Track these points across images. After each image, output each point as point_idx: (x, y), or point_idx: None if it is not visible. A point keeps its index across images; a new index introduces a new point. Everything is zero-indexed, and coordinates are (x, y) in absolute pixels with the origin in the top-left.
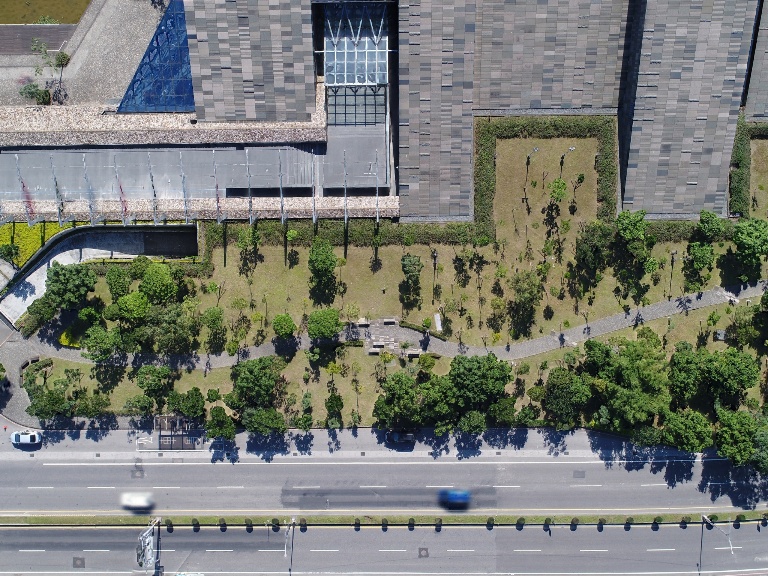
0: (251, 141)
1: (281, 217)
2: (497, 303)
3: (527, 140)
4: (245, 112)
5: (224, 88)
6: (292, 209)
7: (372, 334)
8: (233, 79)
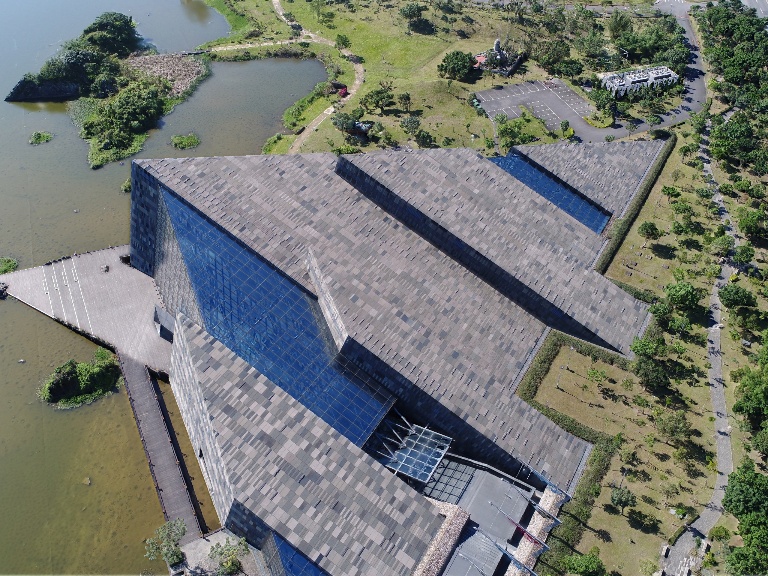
0: (435, 575)
1: (531, 573)
2: (679, 454)
3: (544, 383)
4: (405, 567)
5: (375, 568)
6: (520, 575)
7: (674, 574)
8: (374, 554)
